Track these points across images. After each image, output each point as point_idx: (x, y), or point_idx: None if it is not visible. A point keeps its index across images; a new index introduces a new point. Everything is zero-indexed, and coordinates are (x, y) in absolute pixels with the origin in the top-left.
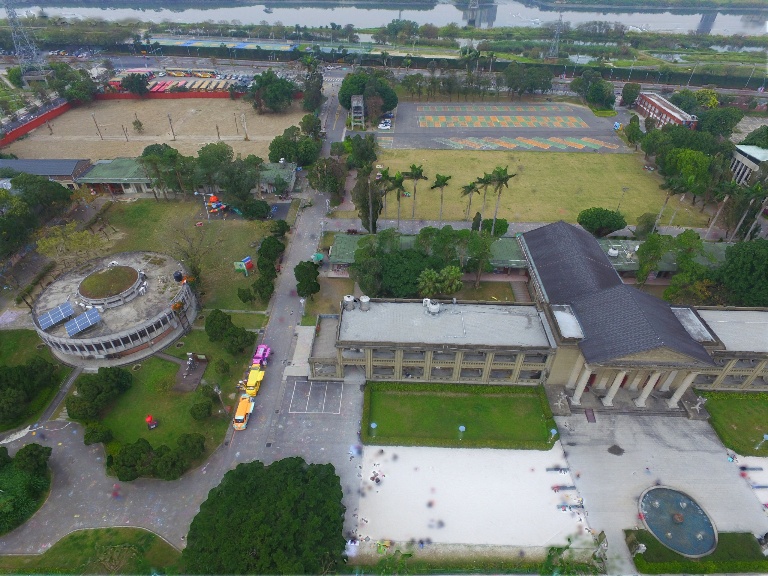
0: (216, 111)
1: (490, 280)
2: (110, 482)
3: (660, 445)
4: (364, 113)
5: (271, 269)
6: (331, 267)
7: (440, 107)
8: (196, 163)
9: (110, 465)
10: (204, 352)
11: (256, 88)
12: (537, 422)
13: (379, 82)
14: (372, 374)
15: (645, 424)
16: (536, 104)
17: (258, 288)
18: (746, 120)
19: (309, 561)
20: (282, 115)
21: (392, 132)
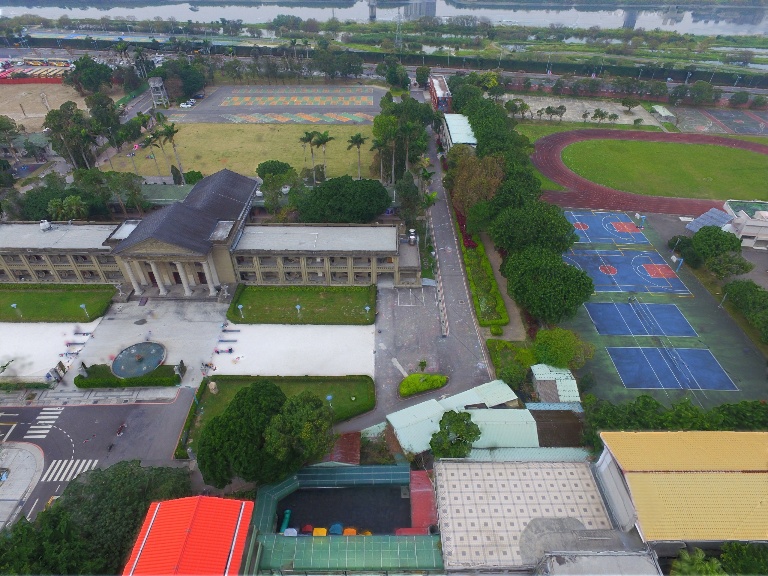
0: None
1: None
2: None
3: (178, 318)
4: (167, 93)
5: None
6: None
7: (255, 90)
8: None
9: None
10: None
11: (75, 72)
12: (98, 306)
13: None
14: None
15: (181, 306)
16: (345, 87)
17: None
18: None
19: None
20: None
21: (190, 110)
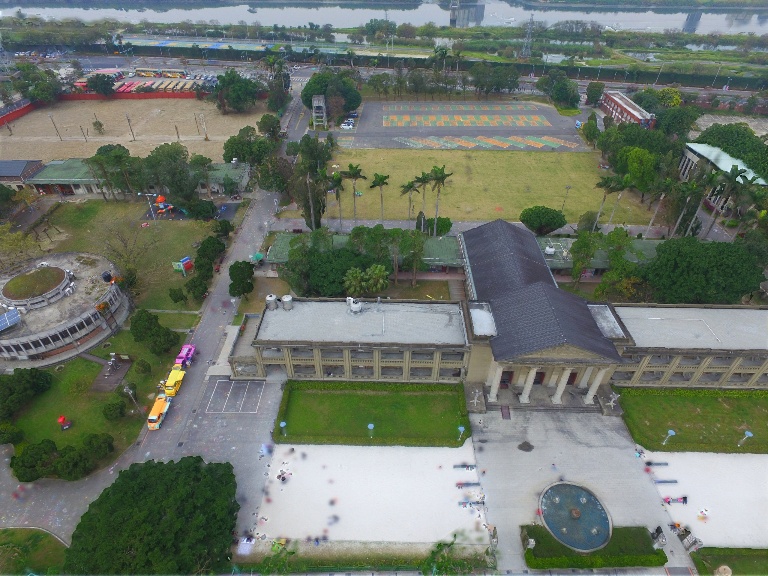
0: (181, 111)
1: (428, 279)
2: (15, 483)
3: (570, 441)
4: (326, 113)
5: (208, 269)
6: (271, 267)
7: (406, 106)
8: (142, 163)
9: (13, 466)
10: (130, 352)
11: (219, 88)
12: (452, 419)
13: (341, 82)
14: (293, 373)
15: (559, 420)
16: (502, 103)
17: (190, 288)
18: (708, 118)
19: (185, 559)
20: (246, 115)
21: (354, 132)
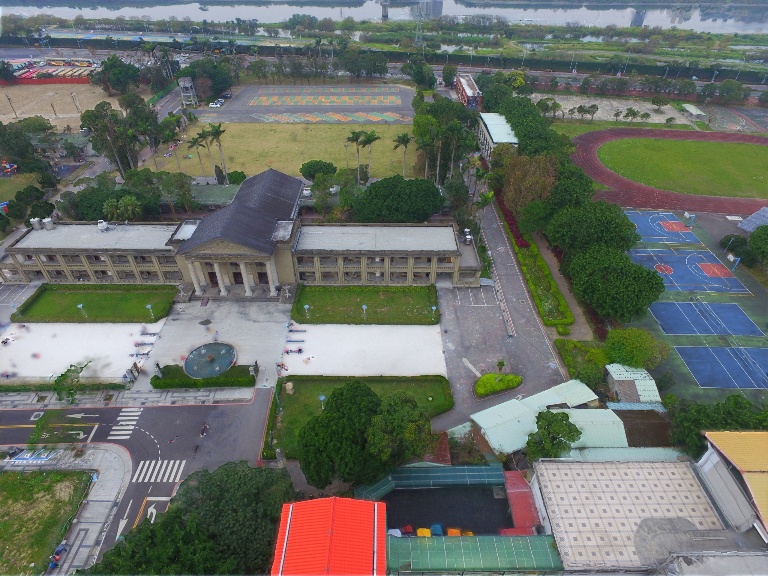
0: None
1: None
2: None
3: (242, 319)
4: (196, 93)
5: (18, 209)
6: None
7: (281, 89)
8: None
9: None
10: None
11: (103, 72)
12: (160, 307)
13: None
14: (51, 278)
15: (243, 307)
16: (371, 86)
17: None
18: None
19: None
20: None
21: (219, 110)
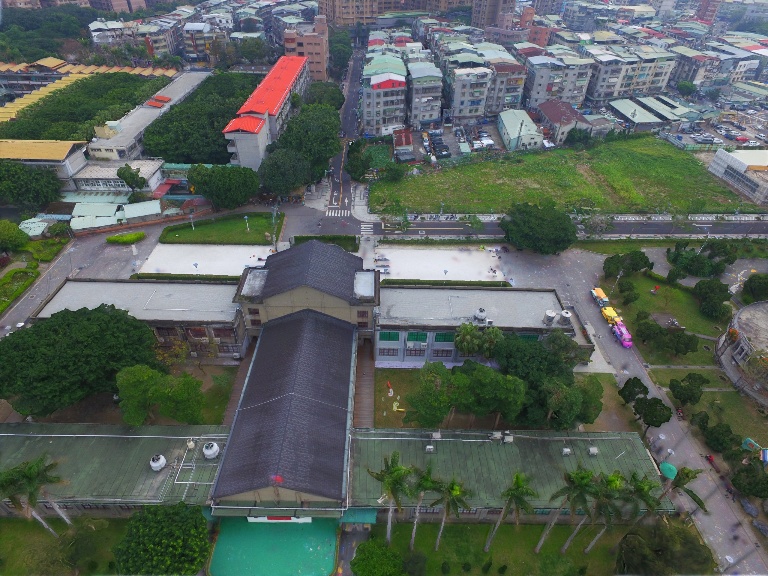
0: None
1: None
2: None
3: None
4: None
5: None
6: None
7: None
8: None
9: None
10: None
11: None
12: None
13: None
14: None
15: None
16: None
17: None
18: None
19: None
20: None
21: None
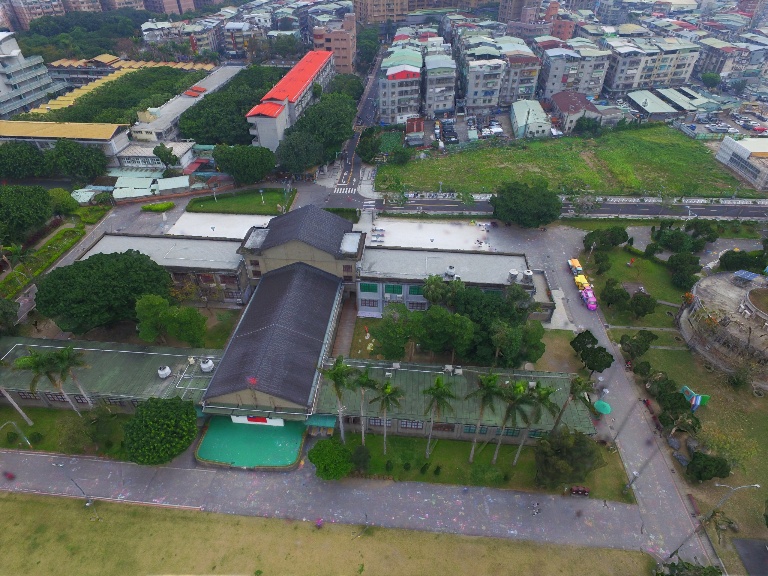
0: None
1: None
2: None
3: None
4: None
5: None
6: None
7: None
8: None
9: None
10: None
11: None
12: None
13: None
14: None
15: None
16: None
17: None
18: None
19: None
20: None
21: None
